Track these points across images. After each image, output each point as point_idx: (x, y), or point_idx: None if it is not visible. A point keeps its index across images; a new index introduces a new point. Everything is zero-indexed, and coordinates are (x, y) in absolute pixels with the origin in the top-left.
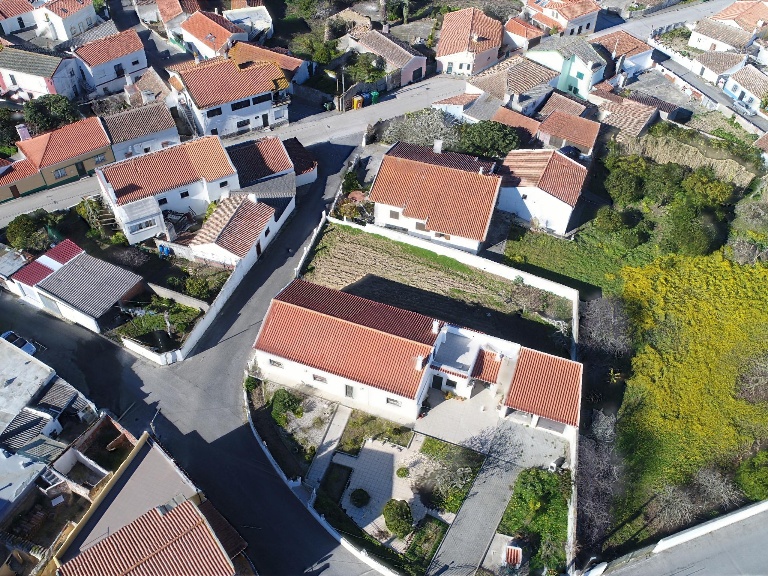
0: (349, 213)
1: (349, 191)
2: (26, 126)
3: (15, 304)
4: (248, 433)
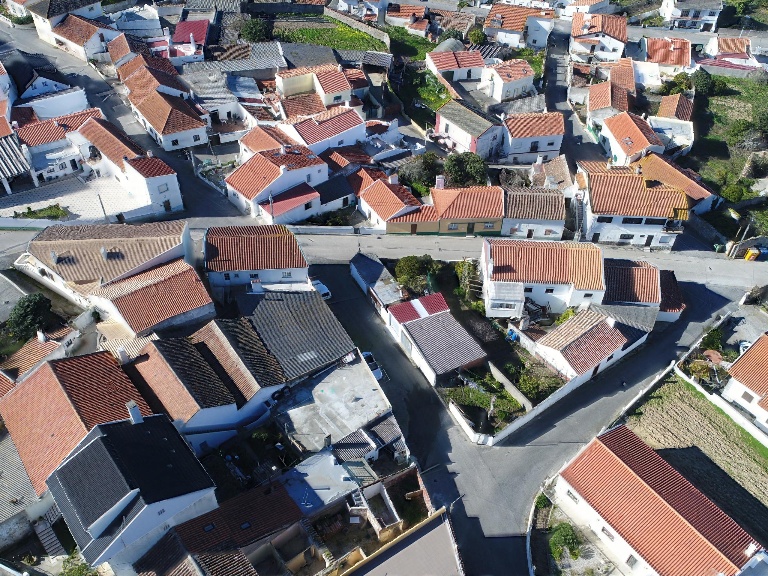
0: (698, 371)
1: (707, 347)
2: (443, 174)
3: (380, 329)
4: (522, 546)
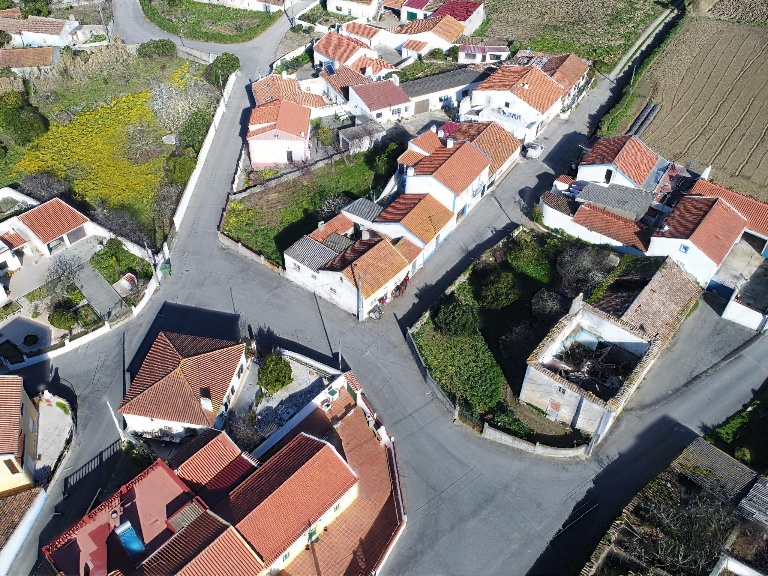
0: None
1: None
2: None
3: None
4: None
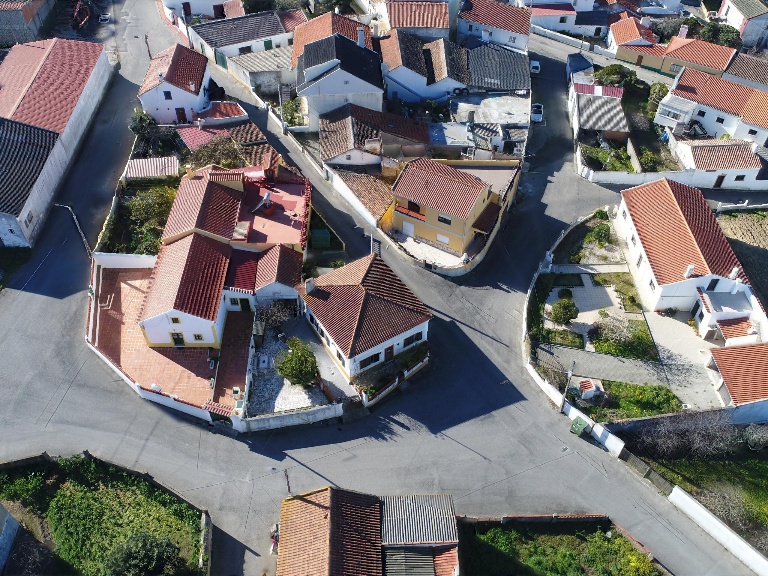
0: None
1: None
2: (695, 35)
3: (563, 101)
4: (566, 228)
